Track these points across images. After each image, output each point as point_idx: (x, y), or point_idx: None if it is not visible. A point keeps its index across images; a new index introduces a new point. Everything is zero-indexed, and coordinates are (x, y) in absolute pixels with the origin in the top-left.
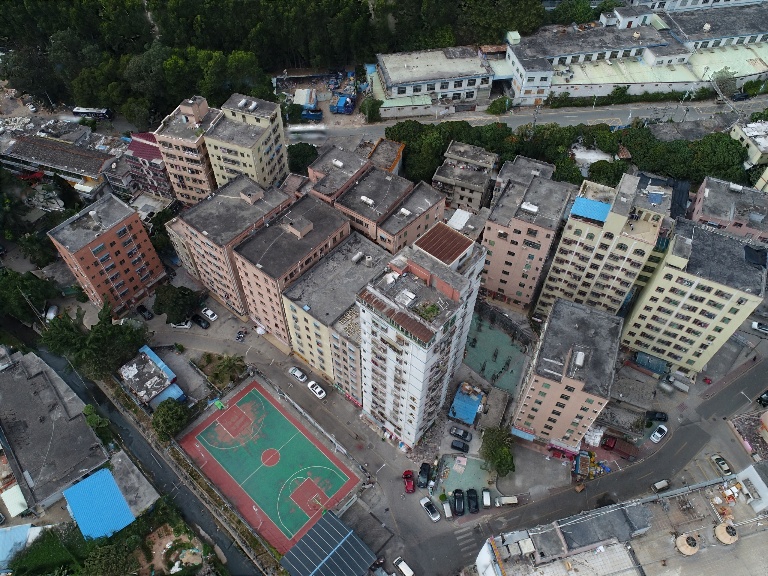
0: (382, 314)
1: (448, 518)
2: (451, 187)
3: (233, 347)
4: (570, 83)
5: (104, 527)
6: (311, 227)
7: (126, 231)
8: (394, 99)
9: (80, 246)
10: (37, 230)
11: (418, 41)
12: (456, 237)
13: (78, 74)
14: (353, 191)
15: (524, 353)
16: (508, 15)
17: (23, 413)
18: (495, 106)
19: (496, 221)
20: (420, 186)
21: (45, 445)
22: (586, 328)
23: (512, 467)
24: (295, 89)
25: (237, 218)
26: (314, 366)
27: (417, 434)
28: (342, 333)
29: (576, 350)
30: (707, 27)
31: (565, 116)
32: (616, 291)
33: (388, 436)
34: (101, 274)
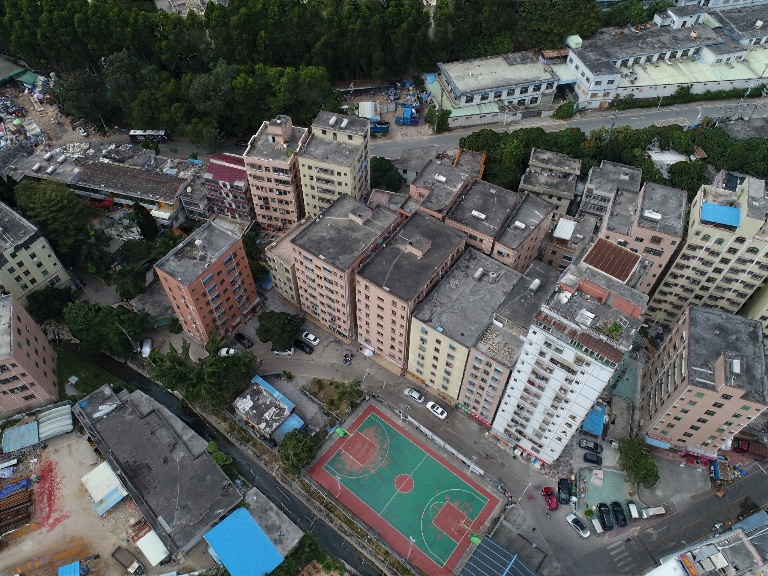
0: (562, 335)
1: (599, 534)
2: (537, 195)
3: (341, 371)
4: (635, 85)
5: (254, 570)
6: (429, 245)
7: (231, 259)
8: (462, 108)
9: (190, 277)
10: (116, 261)
11: (477, 48)
12: (622, 252)
13: (137, 96)
14: (460, 206)
15: (635, 359)
16: (569, 19)
17: (143, 455)
18: (562, 111)
19: (614, 230)
20: (526, 197)
21: (174, 487)
22: (725, 334)
23: (658, 478)
24: (355, 102)
25: (350, 240)
26: (432, 386)
27: (561, 451)
28: (486, 354)
29: (728, 357)
30: (760, 24)
31: (632, 118)
32: (737, 294)
33: (519, 453)
34: (207, 305)
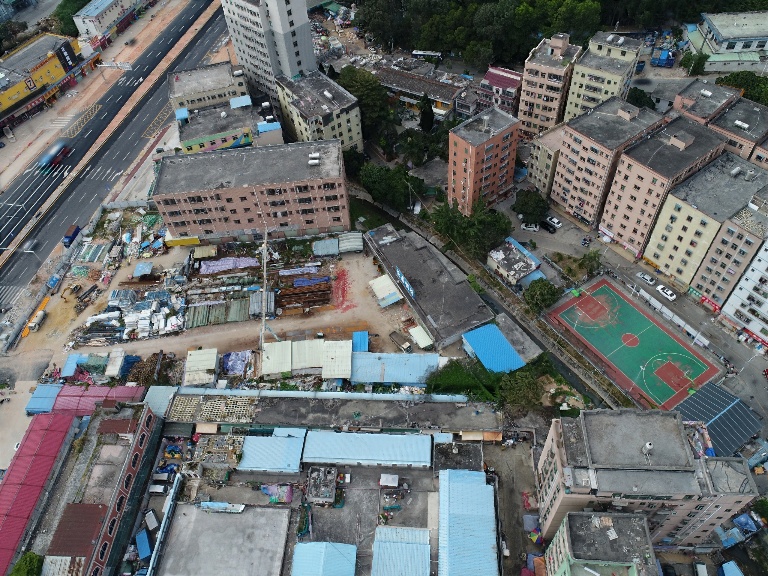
0: None
1: None
2: None
3: (579, 250)
4: None
5: (501, 365)
6: (692, 141)
7: (508, 137)
8: (721, 54)
9: (477, 143)
10: (398, 142)
11: (744, 3)
12: None
13: (428, 20)
14: (723, 117)
15: None
16: None
17: (417, 274)
18: None
19: None
20: None
21: (440, 299)
22: None
23: None
24: None
25: (617, 130)
26: (665, 272)
27: None
28: None
29: None
30: None
31: None
32: None
33: (744, 339)
34: (481, 172)
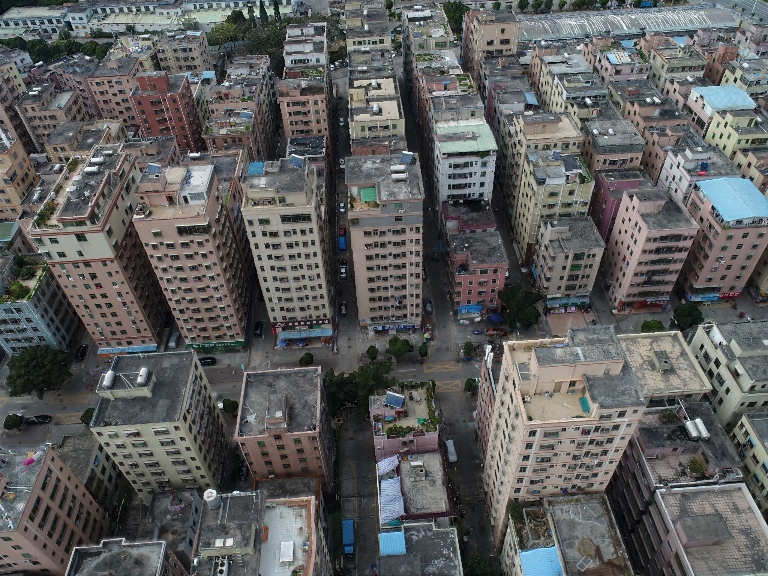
0: None
1: None
2: None
3: None
4: (100, 22)
5: None
6: None
7: None
8: (4, 29)
9: None
10: None
11: (41, 1)
12: None
13: None
14: None
15: None
16: None
17: None
18: None
19: None
20: None
21: None
22: None
23: None
24: None
25: None
26: None
27: None
28: None
29: None
30: None
31: None
32: None
33: None
34: None
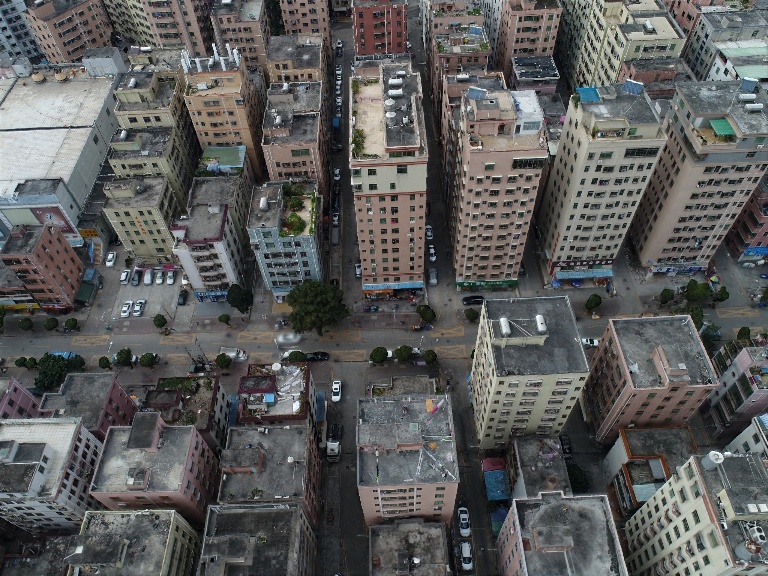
0: None
1: None
2: None
3: None
4: None
5: None
6: None
7: None
8: None
9: None
10: None
11: None
12: None
13: None
14: None
15: None
16: None
17: None
18: None
19: None
20: None
21: None
22: None
23: None
24: None
25: None
26: None
27: None
28: None
29: (45, 1)
30: None
31: None
32: None
33: None
34: None
